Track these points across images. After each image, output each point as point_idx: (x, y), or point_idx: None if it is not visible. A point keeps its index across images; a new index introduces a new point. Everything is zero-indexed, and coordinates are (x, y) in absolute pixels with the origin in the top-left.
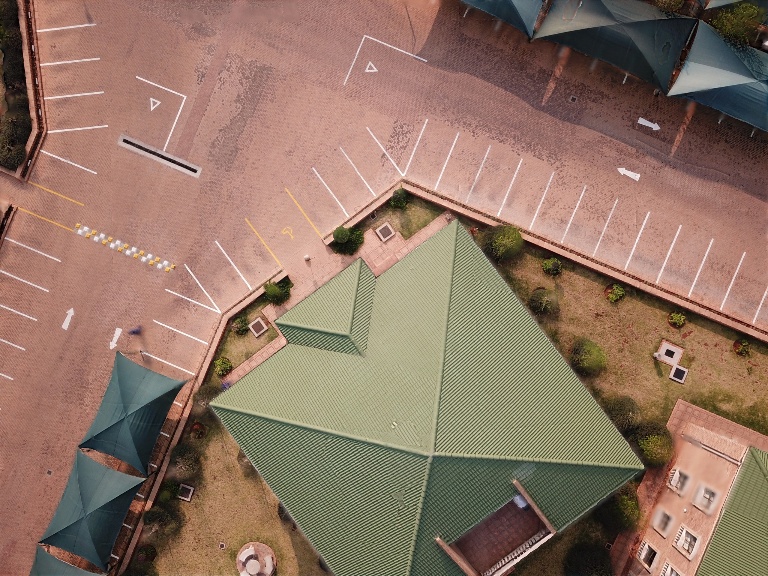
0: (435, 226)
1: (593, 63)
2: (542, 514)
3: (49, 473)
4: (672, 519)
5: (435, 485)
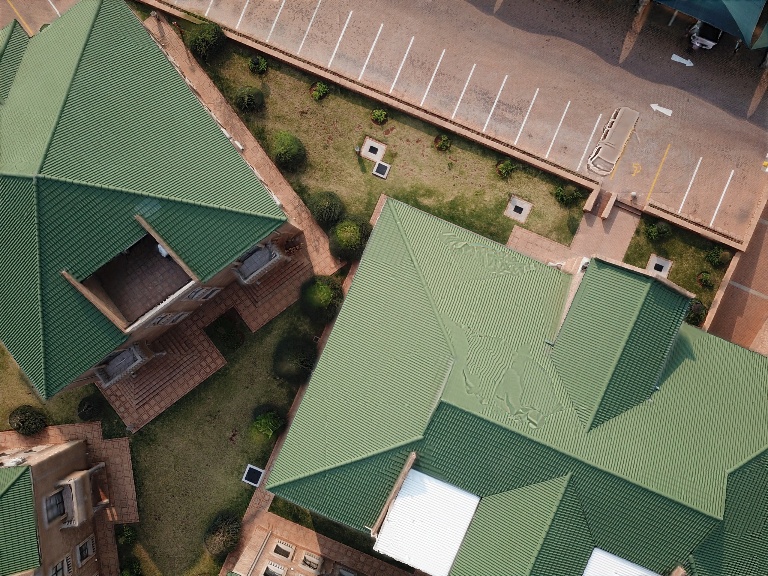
0: None
1: None
2: (177, 257)
3: None
4: None
5: (48, 211)
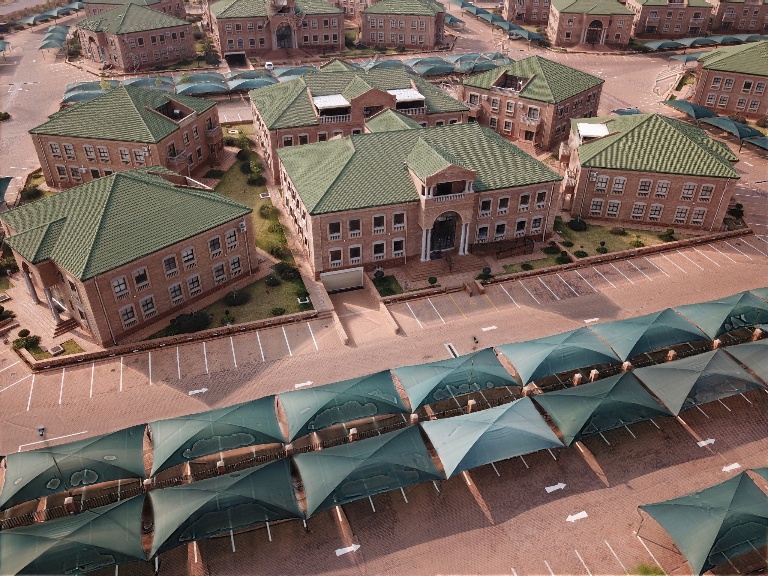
0: None
1: None
2: None
3: None
4: None
5: None
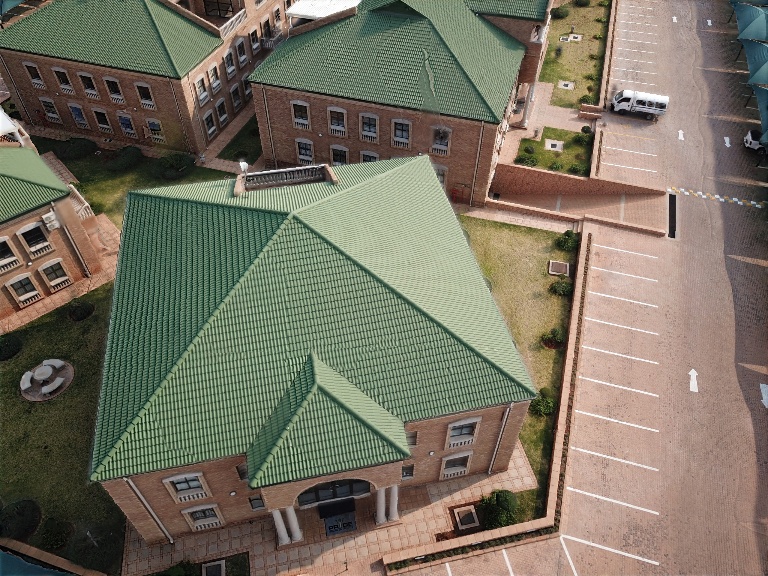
0: None
1: None
2: None
3: None
4: None
5: None
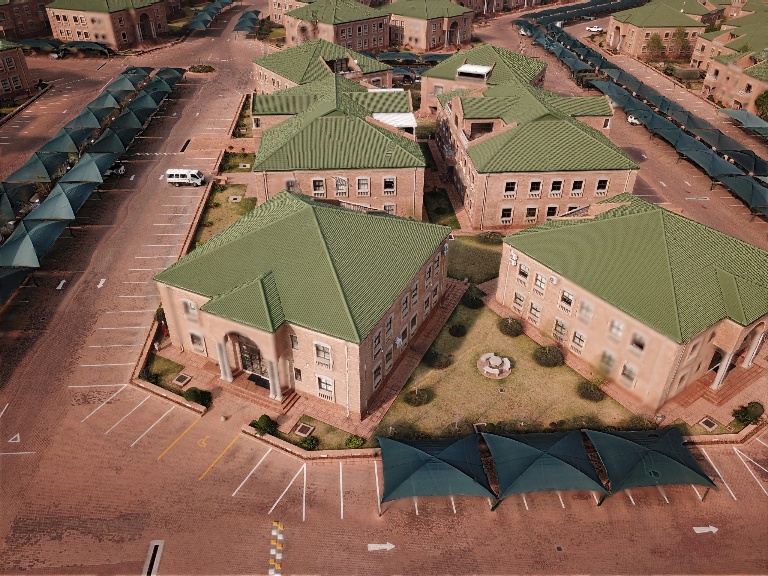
0: (168, 355)
1: (11, 318)
2: None
3: (560, 549)
4: None
5: None
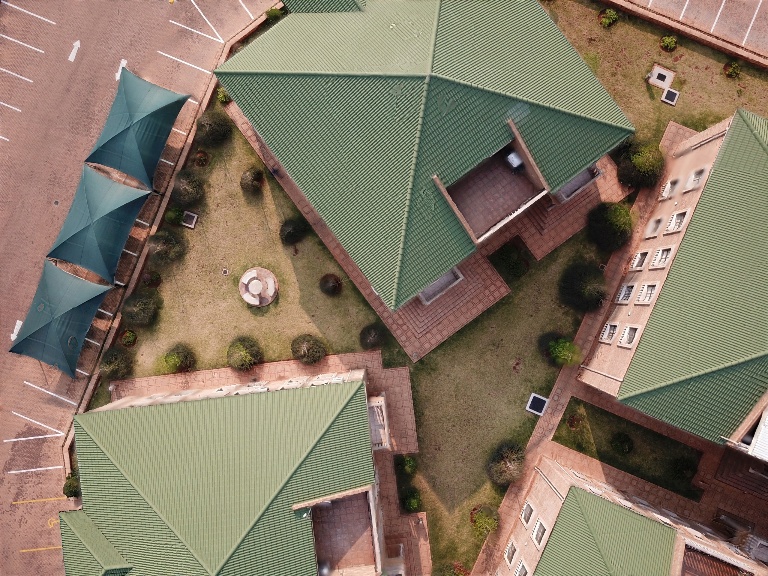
0: None
1: None
2: (536, 165)
3: (56, 203)
4: (663, 218)
5: (432, 112)
